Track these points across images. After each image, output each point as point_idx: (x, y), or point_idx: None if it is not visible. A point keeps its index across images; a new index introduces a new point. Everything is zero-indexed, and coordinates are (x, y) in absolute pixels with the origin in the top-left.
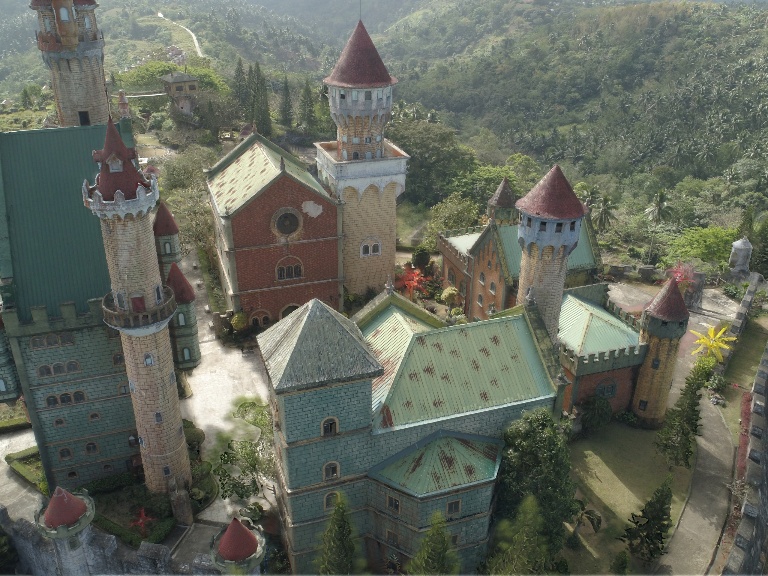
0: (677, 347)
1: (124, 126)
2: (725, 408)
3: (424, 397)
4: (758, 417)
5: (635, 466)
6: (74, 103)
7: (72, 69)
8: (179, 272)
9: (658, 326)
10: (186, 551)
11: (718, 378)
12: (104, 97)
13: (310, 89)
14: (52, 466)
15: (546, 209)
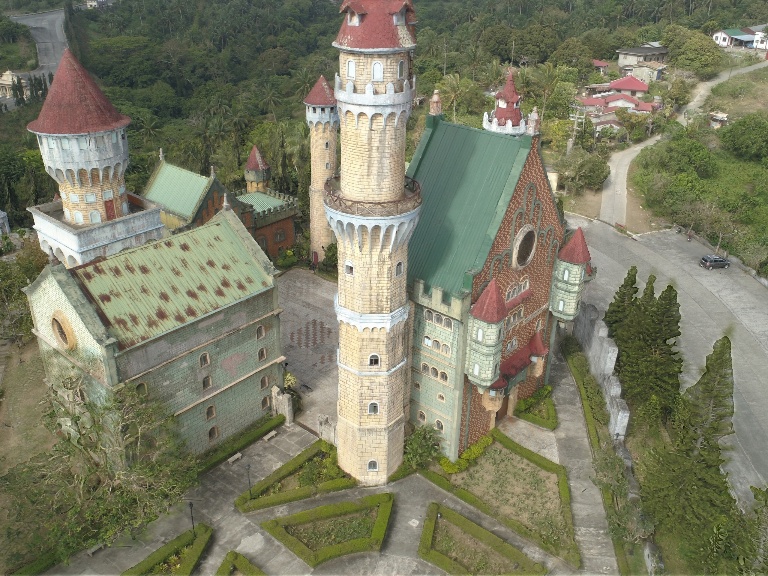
0: None
1: None
2: None
3: None
4: None
5: None
6: None
7: None
8: None
9: None
10: None
11: None
12: None
13: None
14: None
15: None
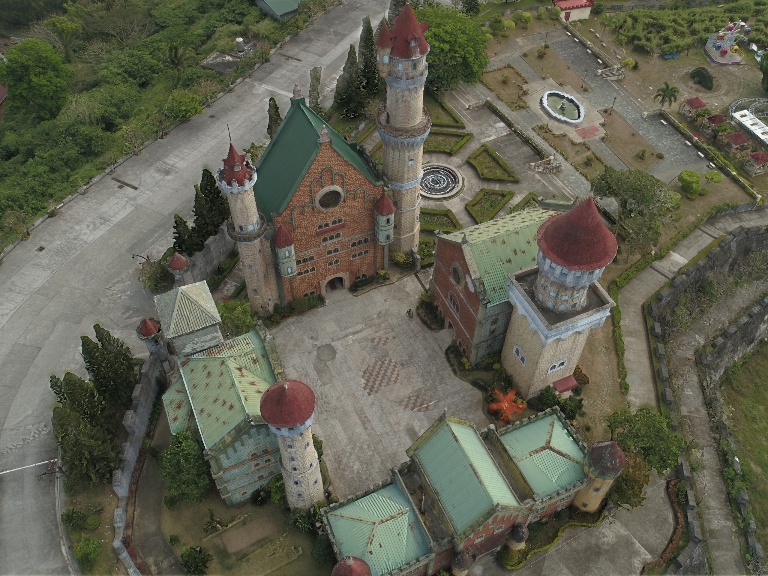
0: None
1: None
2: None
3: (197, 377)
4: None
5: None
6: None
7: None
8: (281, 230)
9: None
10: None
11: None
12: (404, 112)
13: None
14: None
15: None
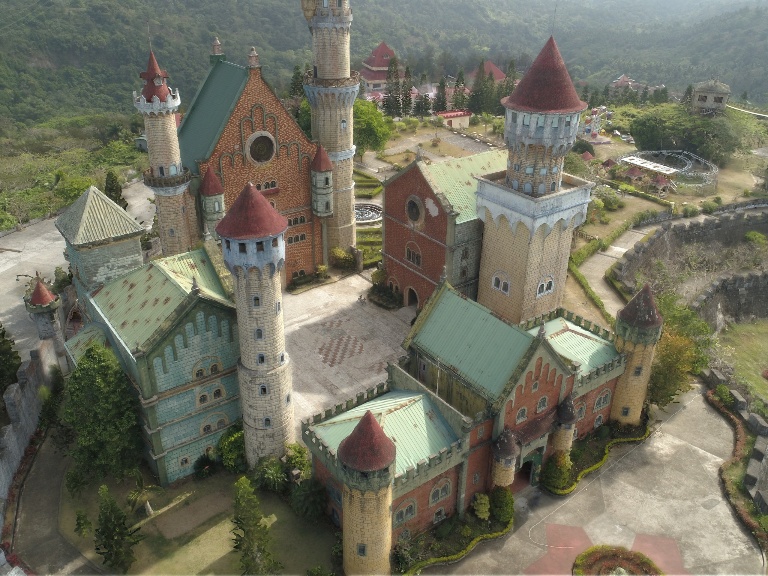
0: None
1: None
2: None
3: (114, 297)
4: None
5: None
6: None
7: (313, 35)
8: (209, 174)
9: None
10: None
11: None
12: (332, 60)
13: None
14: None
15: None
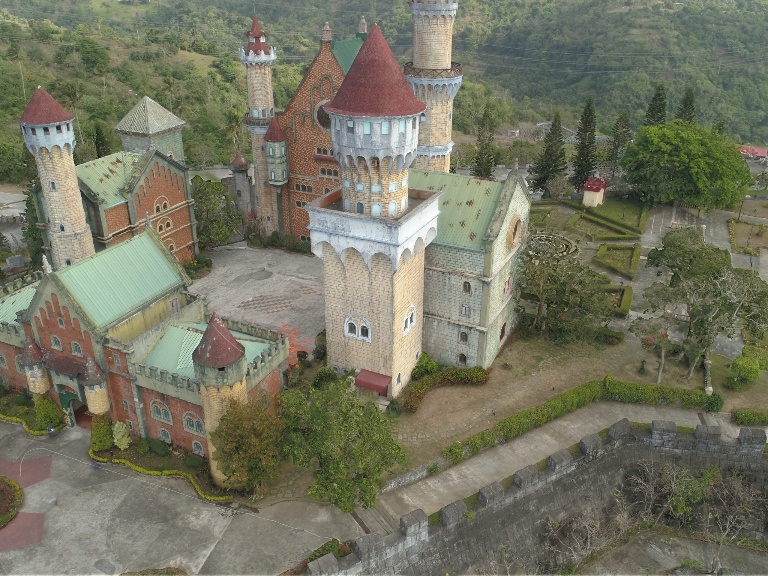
0: None
1: None
2: None
3: None
4: None
5: None
6: None
7: None
8: None
9: None
10: (234, 234)
11: None
12: None
13: None
14: None
15: None
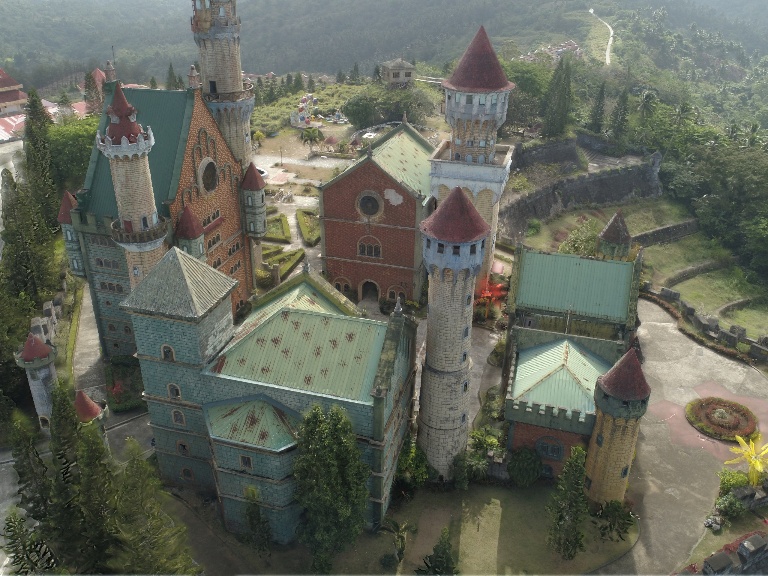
0: (626, 430)
1: (189, 94)
2: (715, 535)
3: (258, 361)
4: (724, 556)
5: (530, 535)
6: (207, 74)
7: (207, 47)
8: (189, 214)
9: (600, 397)
10: (135, 425)
11: (730, 499)
12: (232, 72)
13: (627, 96)
14: (104, 334)
15: (432, 227)
